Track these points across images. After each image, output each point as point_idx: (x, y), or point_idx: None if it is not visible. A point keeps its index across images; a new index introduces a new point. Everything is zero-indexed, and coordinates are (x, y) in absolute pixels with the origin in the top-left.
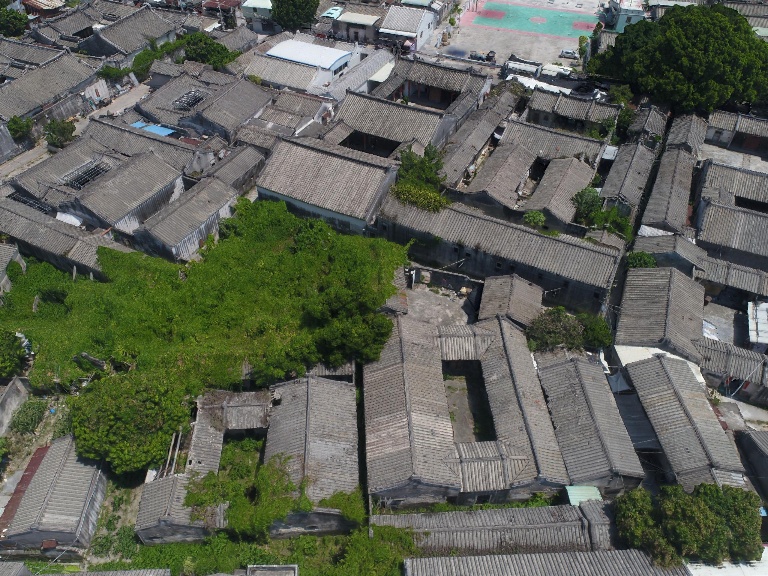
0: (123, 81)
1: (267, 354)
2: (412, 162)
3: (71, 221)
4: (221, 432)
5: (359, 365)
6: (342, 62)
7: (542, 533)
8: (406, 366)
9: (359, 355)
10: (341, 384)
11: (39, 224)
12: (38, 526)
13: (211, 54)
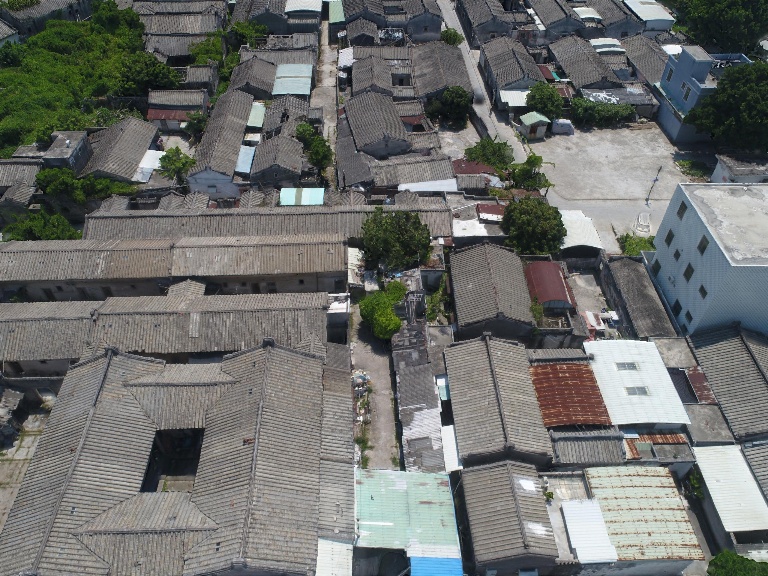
0: None
1: None
2: None
3: None
4: None
5: None
6: None
7: (246, 5)
8: None
9: None
10: None
11: None
12: None
13: None
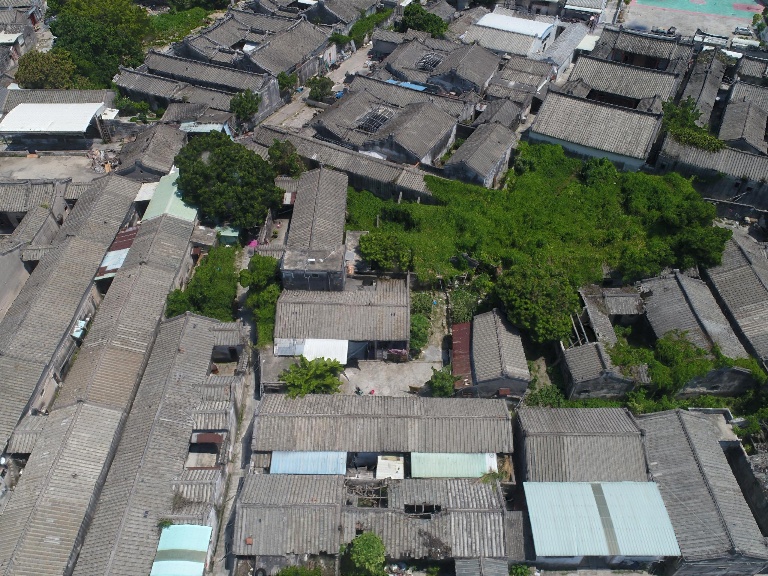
0: (345, 48)
1: (626, 257)
2: (673, 112)
3: (376, 157)
4: (607, 316)
5: (701, 269)
6: (547, 33)
7: None
8: (754, 267)
9: (702, 260)
10: (697, 282)
11: (360, 157)
12: (508, 373)
13: (428, 24)
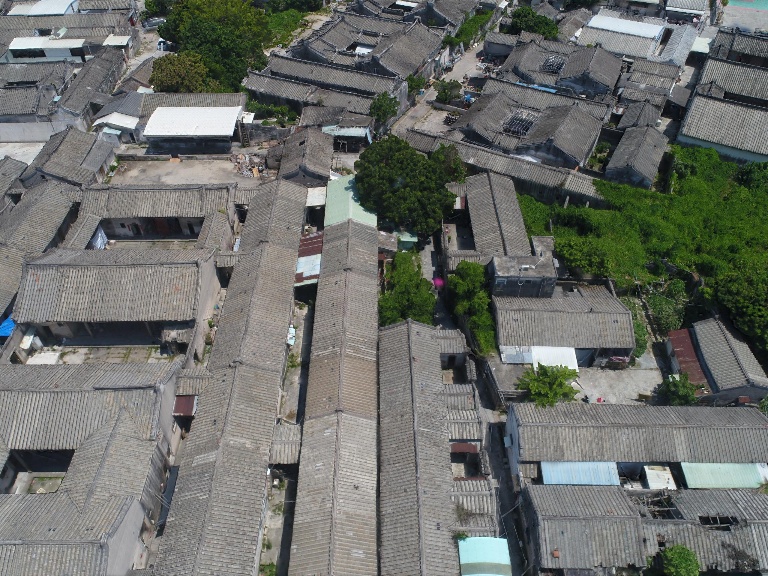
0: (455, 50)
1: None
2: None
3: None
4: None
5: None
6: (659, 35)
7: None
8: None
9: None
10: None
11: (520, 161)
12: (754, 381)
13: (539, 26)
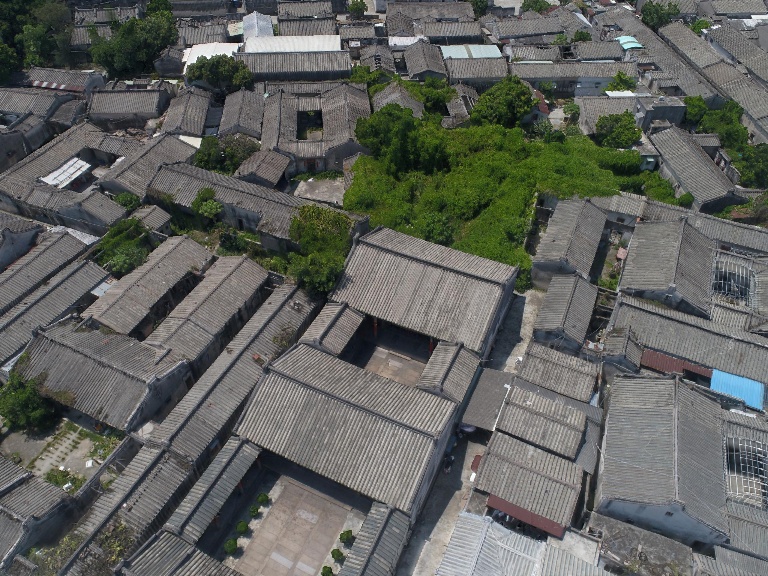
0: None
1: None
2: None
3: None
4: None
5: None
6: None
7: None
8: None
9: None
10: None
11: None
12: None
13: None
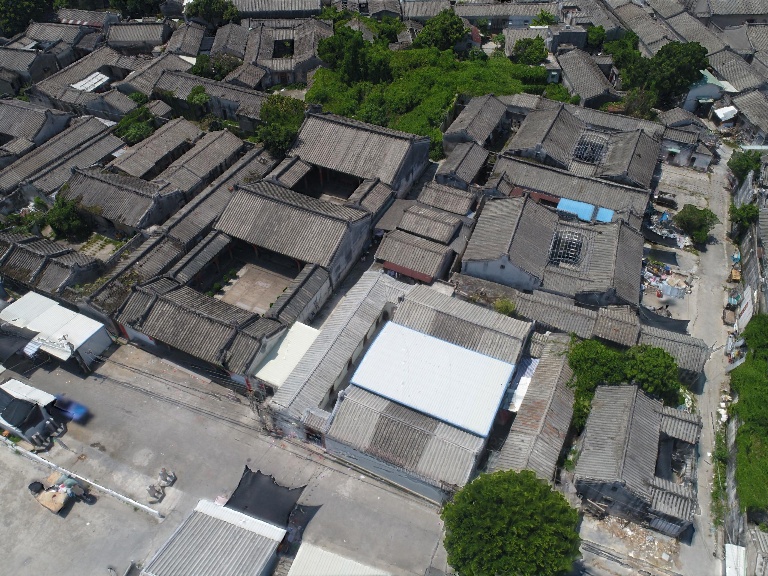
0: None
1: None
2: None
3: None
4: None
5: None
6: None
7: None
8: None
9: None
10: None
11: None
12: None
13: None
